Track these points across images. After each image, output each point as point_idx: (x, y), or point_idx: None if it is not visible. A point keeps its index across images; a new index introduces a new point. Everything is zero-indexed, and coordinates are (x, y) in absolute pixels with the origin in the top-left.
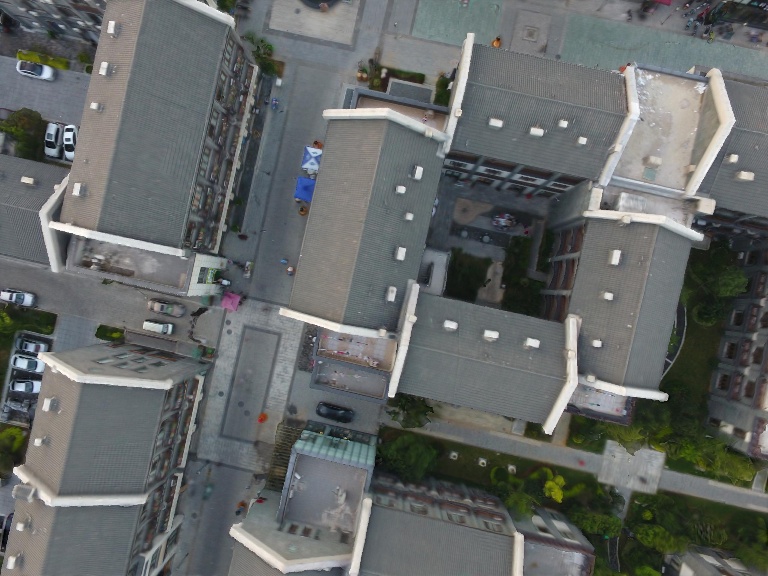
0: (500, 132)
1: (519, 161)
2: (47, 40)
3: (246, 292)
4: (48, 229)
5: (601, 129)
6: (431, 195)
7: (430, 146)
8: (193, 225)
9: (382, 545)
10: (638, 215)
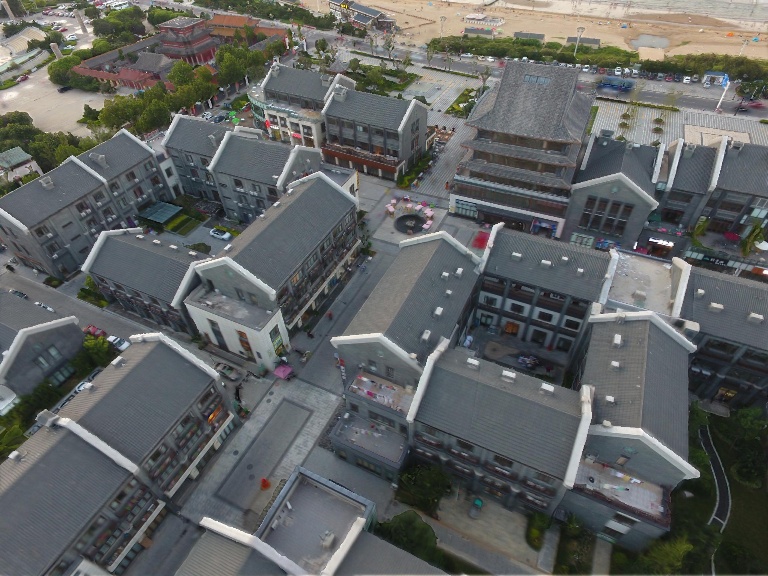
0: (520, 263)
1: (535, 284)
2: (235, 225)
3: (296, 374)
4: (190, 274)
5: (594, 267)
6: (467, 291)
7: (469, 264)
8: (286, 293)
9: (365, 568)
10: (630, 313)
